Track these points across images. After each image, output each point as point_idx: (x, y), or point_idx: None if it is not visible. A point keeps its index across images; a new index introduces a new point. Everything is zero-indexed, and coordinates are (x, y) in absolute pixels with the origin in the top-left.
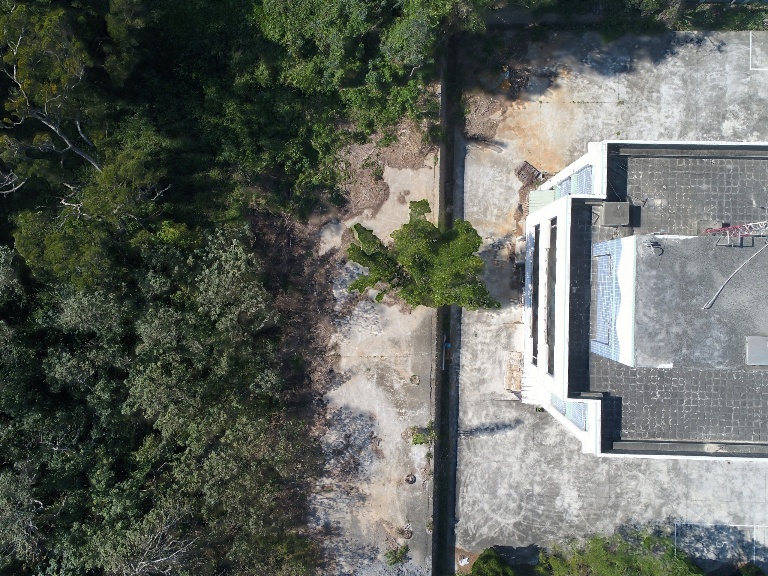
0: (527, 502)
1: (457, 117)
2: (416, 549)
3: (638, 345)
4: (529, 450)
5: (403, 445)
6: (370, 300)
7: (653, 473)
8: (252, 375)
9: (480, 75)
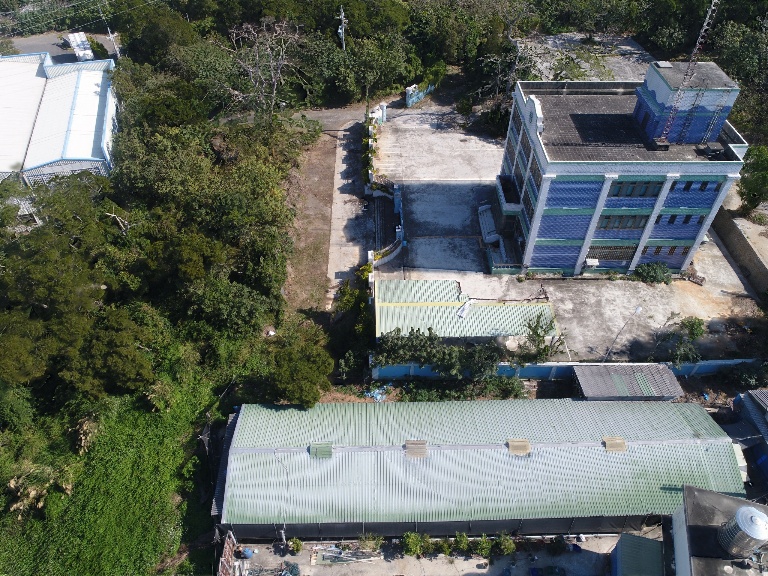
0: None
1: (765, 308)
2: None
3: None
4: None
5: None
6: None
7: None
8: None
9: (765, 328)
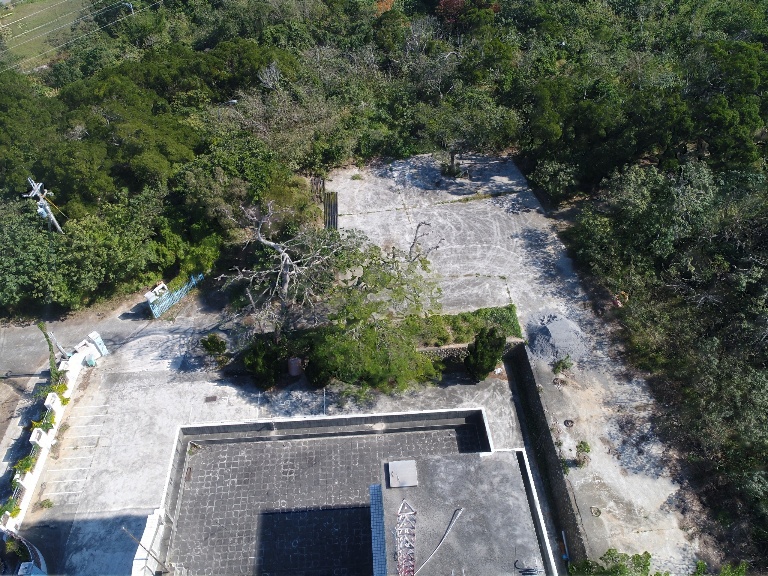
0: None
1: None
2: (547, 372)
3: (516, 470)
4: None
5: None
6: None
7: None
8: (767, 495)
9: None
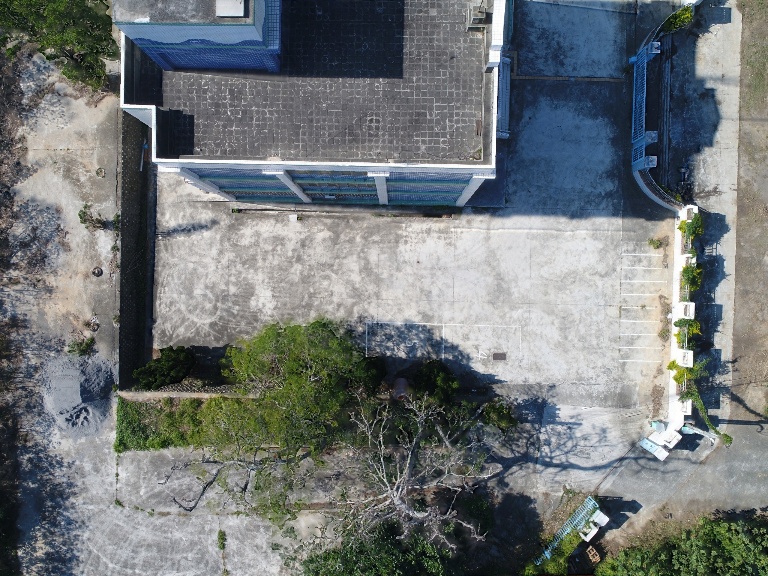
0: (222, 302)
1: None
2: (103, 342)
3: None
4: (225, 251)
5: (90, 238)
6: (56, 93)
7: (345, 273)
8: None
9: None
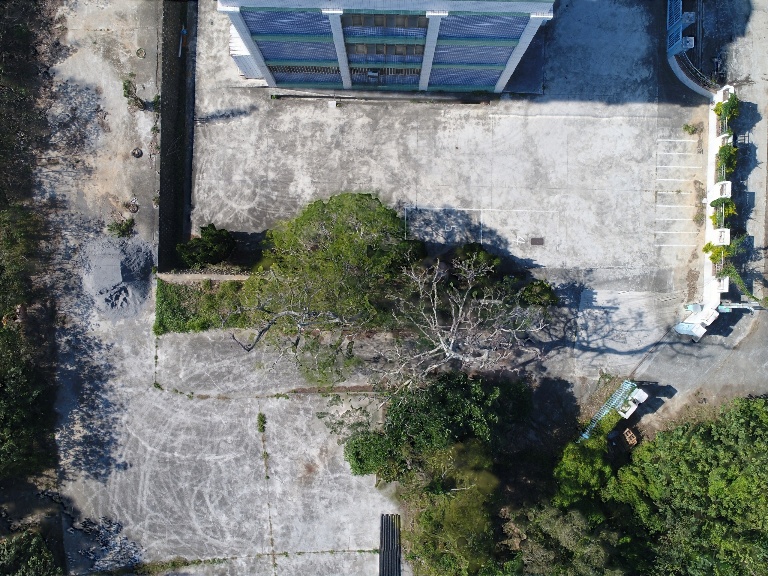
0: (261, 188)
1: None
2: (142, 223)
3: None
4: (264, 137)
5: (129, 119)
6: None
7: (384, 159)
8: None
9: None
